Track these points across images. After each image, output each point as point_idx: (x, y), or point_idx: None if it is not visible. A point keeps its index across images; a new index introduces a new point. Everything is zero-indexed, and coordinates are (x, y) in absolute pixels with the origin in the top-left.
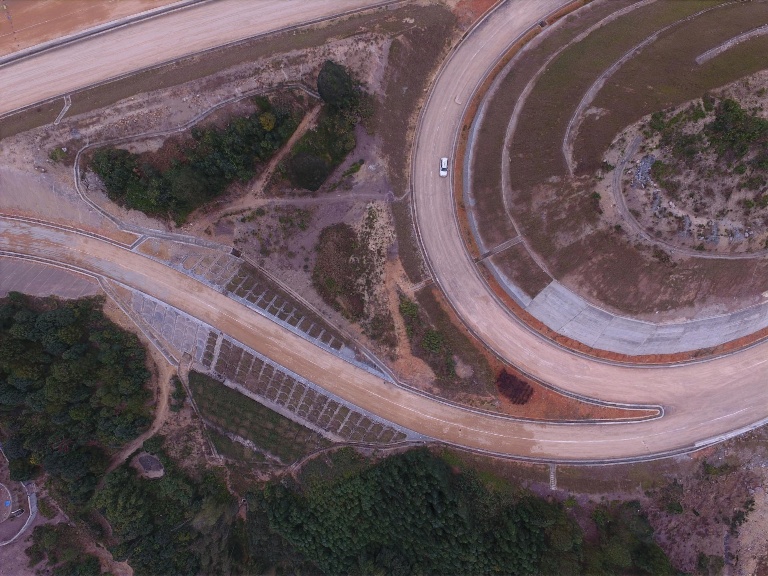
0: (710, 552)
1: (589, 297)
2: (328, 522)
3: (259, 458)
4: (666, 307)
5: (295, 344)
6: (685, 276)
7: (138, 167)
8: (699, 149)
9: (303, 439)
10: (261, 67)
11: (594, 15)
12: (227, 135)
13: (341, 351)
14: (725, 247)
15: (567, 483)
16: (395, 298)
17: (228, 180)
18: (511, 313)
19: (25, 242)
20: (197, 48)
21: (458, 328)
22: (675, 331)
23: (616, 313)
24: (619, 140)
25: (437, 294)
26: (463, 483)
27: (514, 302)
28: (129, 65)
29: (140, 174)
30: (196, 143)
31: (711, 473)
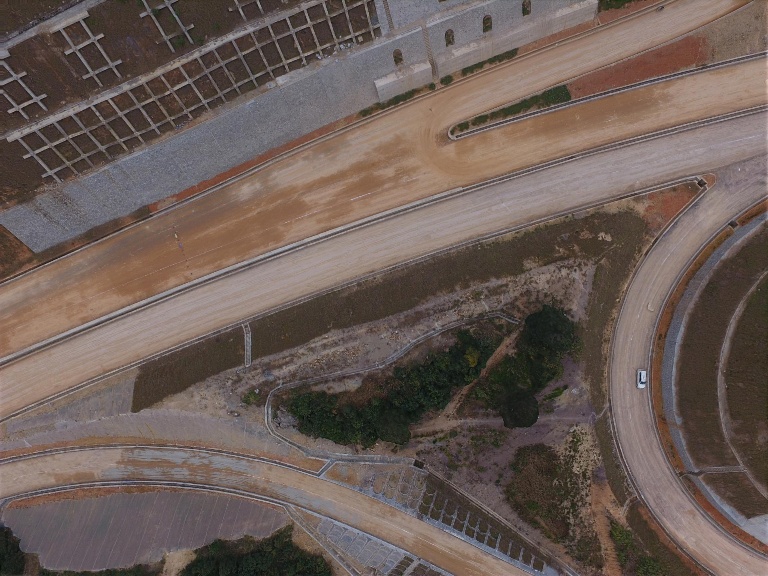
0: None
1: None
2: None
3: None
4: None
5: (496, 567)
6: None
7: (336, 407)
8: None
9: None
10: (460, 299)
11: None
12: (430, 372)
13: (544, 572)
14: None
15: None
16: (604, 522)
17: (425, 410)
18: (719, 527)
19: (205, 472)
20: (377, 266)
21: (668, 547)
22: None
23: None
24: None
25: (643, 512)
26: None
27: (723, 517)
28: (307, 287)
29: (337, 412)
30: (399, 383)
31: None
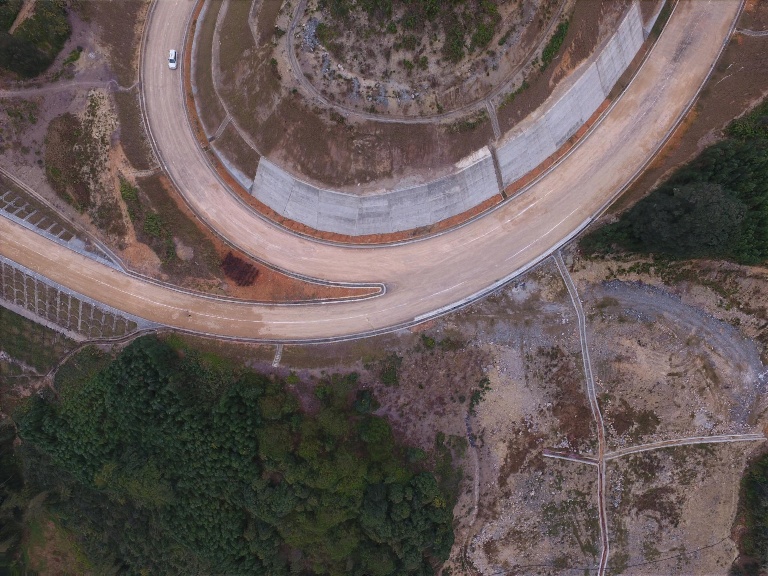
0: (450, 432)
1: (295, 172)
2: (77, 427)
3: (16, 370)
4: (365, 178)
5: (22, 236)
6: (371, 143)
7: None
8: (348, 7)
9: (49, 342)
10: None
11: None
12: None
13: (70, 242)
14: (396, 109)
15: (290, 360)
16: (118, 184)
17: None
18: (240, 200)
19: None
20: None
21: (185, 214)
22: (381, 204)
23: (321, 186)
24: (286, 5)
25: (165, 182)
26: (185, 364)
27: (242, 188)
28: None
29: None
30: None
31: (428, 344)
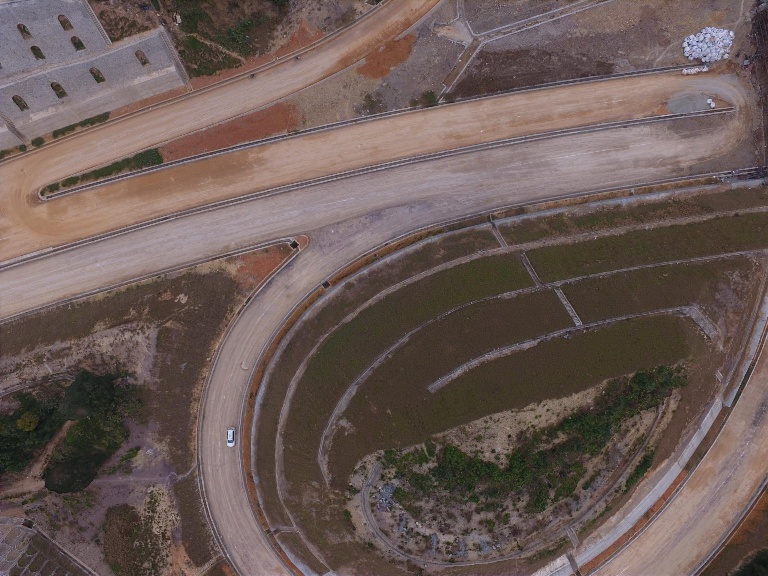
0: None
1: None
2: None
3: None
4: None
5: None
6: None
7: None
8: (429, 487)
9: None
10: (23, 362)
11: (366, 289)
12: None
13: None
14: (476, 558)
15: None
16: None
17: None
18: None
19: None
20: None
21: None
22: None
23: None
24: (361, 467)
25: (228, 571)
26: None
27: None
28: None
29: None
30: None
31: None
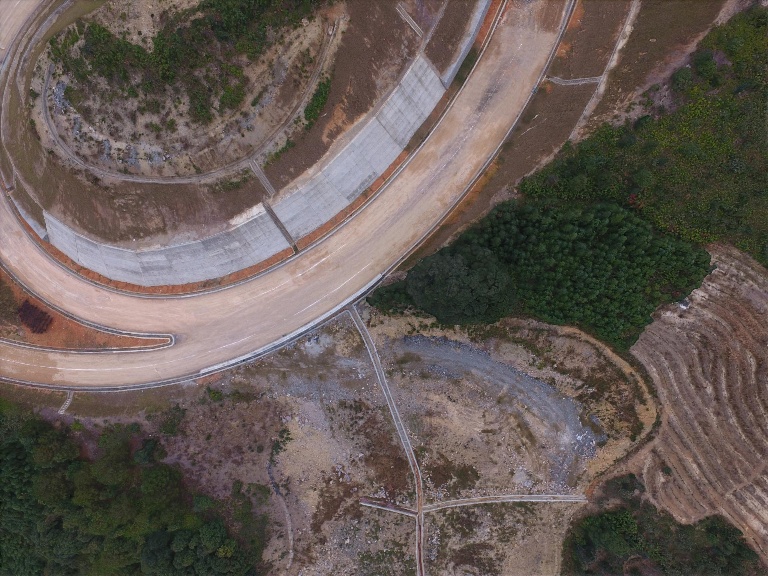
0: (249, 480)
1: (74, 226)
2: None
3: None
4: (138, 234)
5: None
6: (134, 201)
7: None
8: (85, 73)
9: None
10: None
11: None
12: None
13: None
14: (150, 171)
15: (77, 408)
16: None
17: None
18: (41, 247)
19: None
20: None
21: None
22: (159, 259)
23: (98, 241)
24: (37, 68)
25: None
26: None
27: None
28: None
29: None
30: None
31: None
